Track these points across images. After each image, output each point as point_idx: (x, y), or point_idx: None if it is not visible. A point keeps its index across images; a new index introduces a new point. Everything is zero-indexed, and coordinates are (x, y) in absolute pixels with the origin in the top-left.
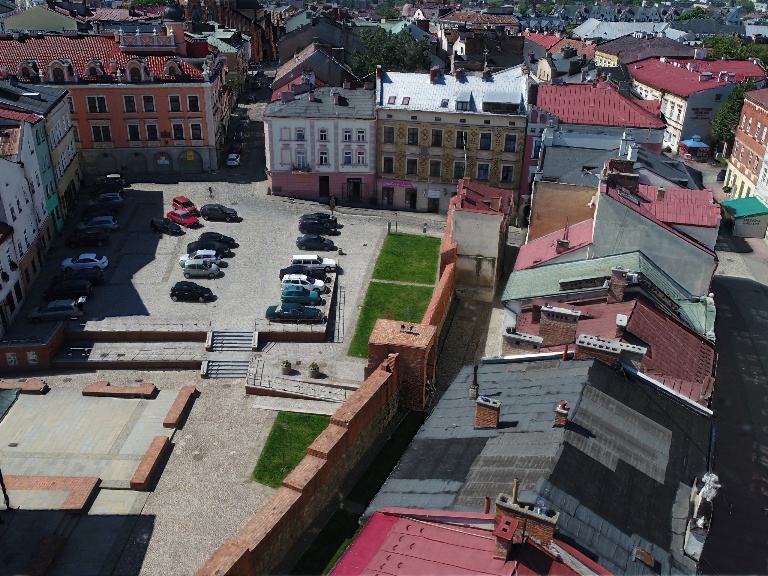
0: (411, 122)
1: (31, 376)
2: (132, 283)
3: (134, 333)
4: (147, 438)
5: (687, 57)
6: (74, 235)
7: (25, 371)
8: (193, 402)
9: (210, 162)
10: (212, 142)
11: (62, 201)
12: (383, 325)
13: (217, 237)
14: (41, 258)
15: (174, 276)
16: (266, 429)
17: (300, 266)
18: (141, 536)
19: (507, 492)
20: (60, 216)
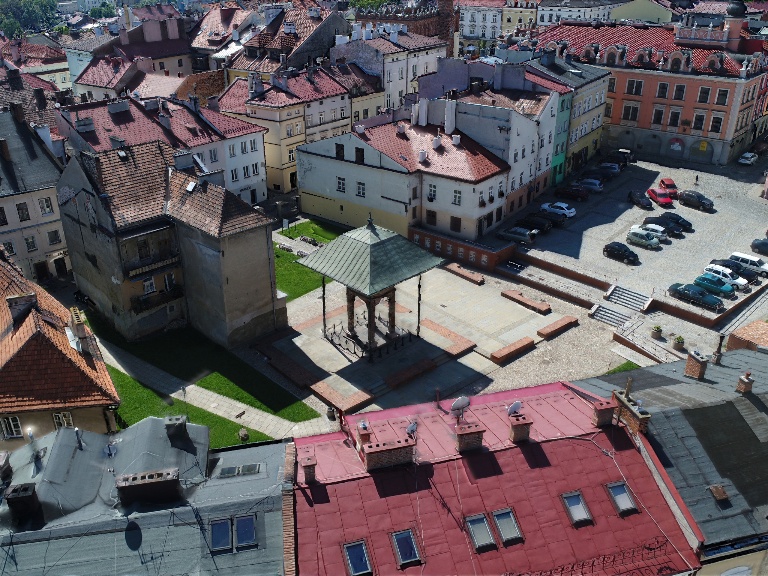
0: None
1: (479, 272)
2: (583, 234)
3: (559, 267)
4: (522, 336)
5: None
6: (563, 188)
7: (478, 268)
8: (569, 328)
9: (720, 156)
10: (729, 137)
11: (569, 160)
12: (759, 326)
13: (676, 218)
14: (530, 198)
15: (619, 238)
16: (609, 367)
17: (733, 261)
18: (478, 386)
19: (646, 404)
20: (562, 172)
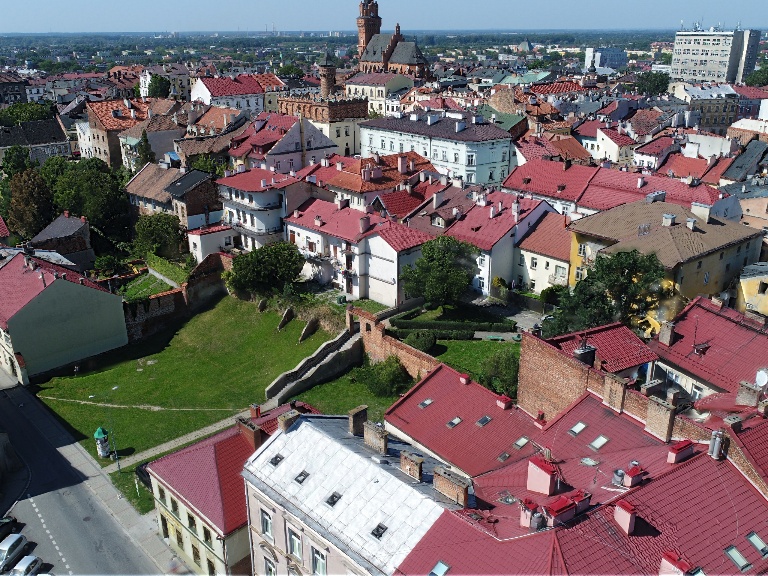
0: (702, 104)
1: None
2: None
3: None
4: None
5: None
6: None
7: None
8: None
9: None
10: None
11: None
12: None
13: None
14: None
15: None
16: None
17: None
18: None
19: None
20: None
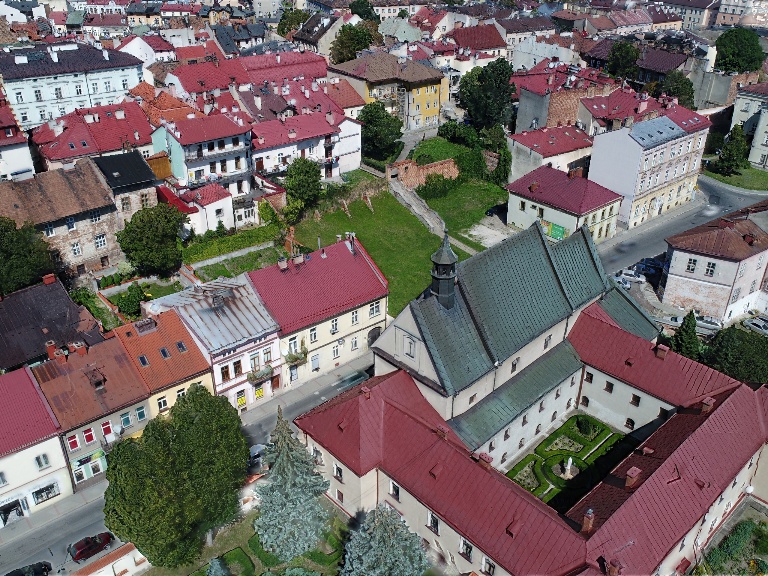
0: None
1: None
2: None
3: None
4: None
5: None
6: None
7: None
8: None
9: None
10: None
11: None
12: None
13: None
14: None
15: None
16: None
17: None
18: None
19: None
20: None
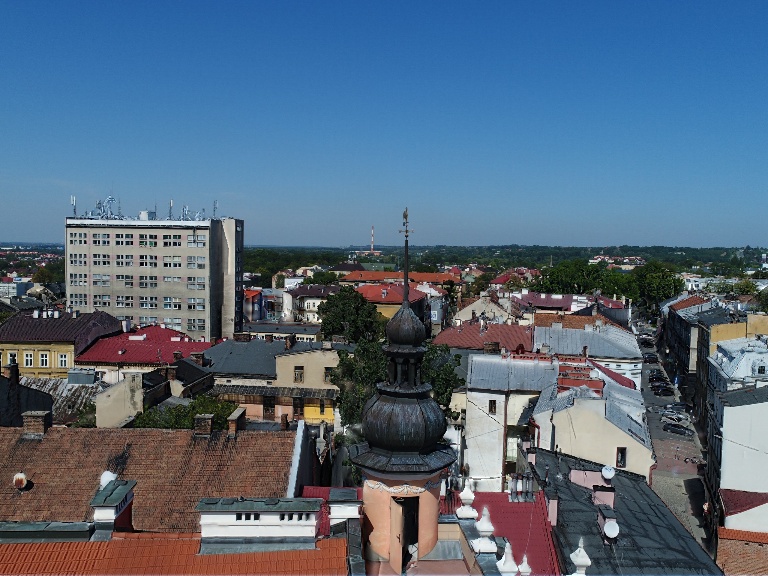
0: None
1: None
2: None
3: None
4: None
5: (119, 332)
6: None
7: None
8: None
9: None
10: None
11: None
12: None
13: None
14: None
15: None
16: None
17: None
18: None
19: None
20: None
